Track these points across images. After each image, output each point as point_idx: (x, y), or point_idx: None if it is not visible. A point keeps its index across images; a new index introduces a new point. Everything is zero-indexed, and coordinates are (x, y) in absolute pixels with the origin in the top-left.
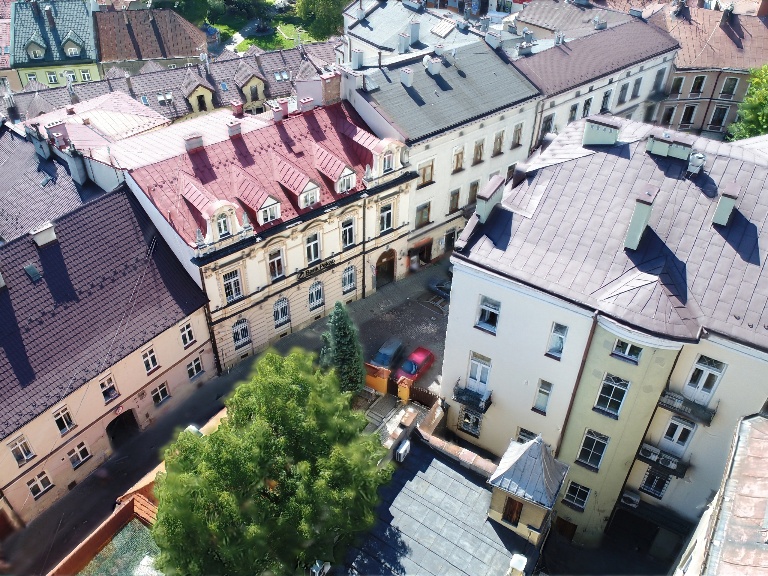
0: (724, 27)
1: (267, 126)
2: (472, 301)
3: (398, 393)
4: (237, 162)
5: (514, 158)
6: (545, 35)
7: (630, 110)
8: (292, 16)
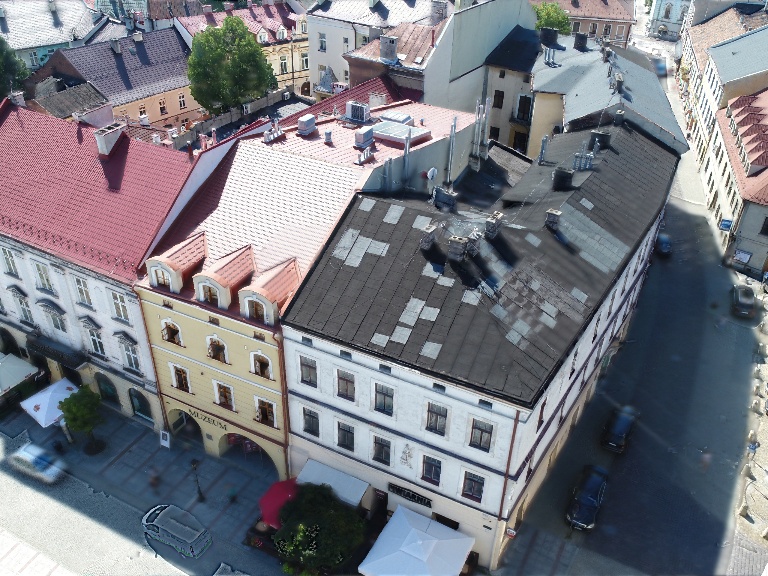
0: None
1: None
2: (316, 37)
3: None
4: None
5: None
6: None
7: None
8: None
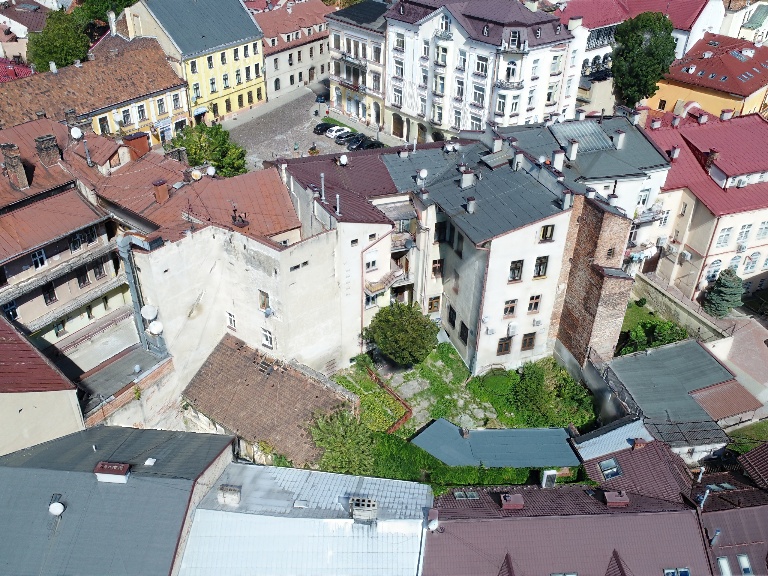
0: None
1: (682, 125)
2: None
3: None
4: None
5: None
6: None
7: None
8: None
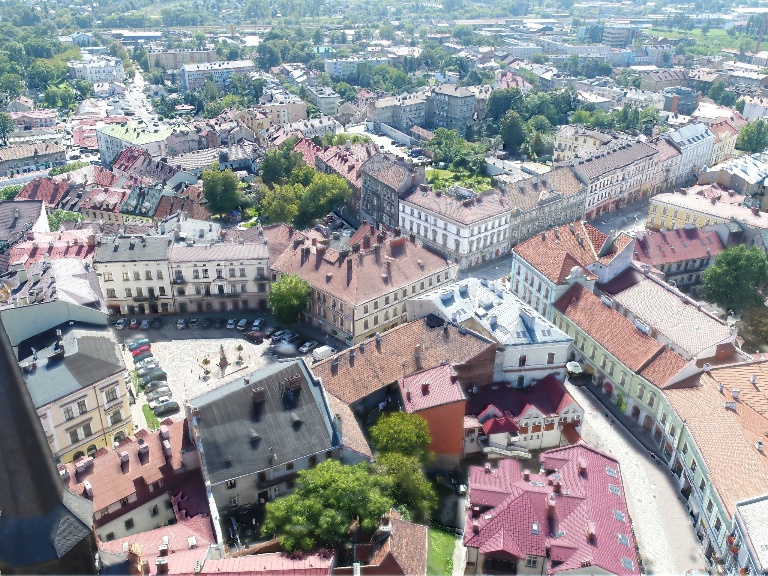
0: (302, 256)
1: None
2: None
3: None
4: None
5: (162, 284)
6: None
7: (243, 282)
8: None
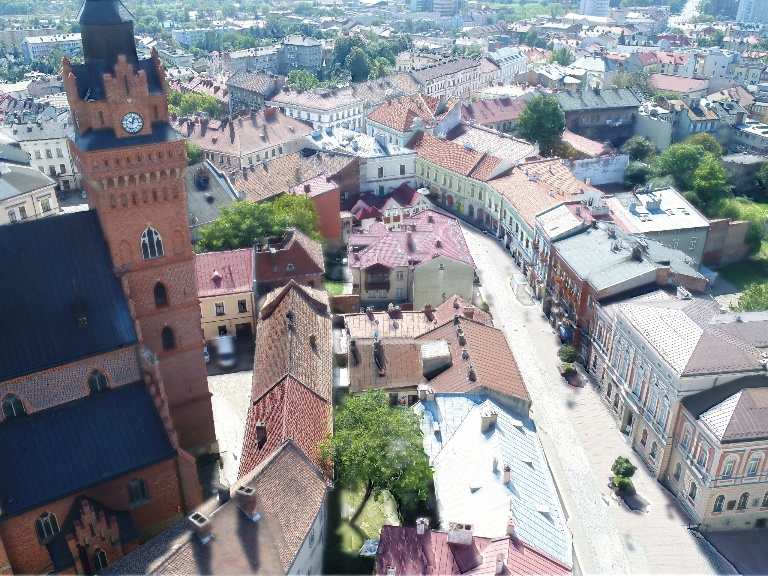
0: None
1: None
2: None
3: None
4: None
5: (62, 162)
6: None
7: None
8: None
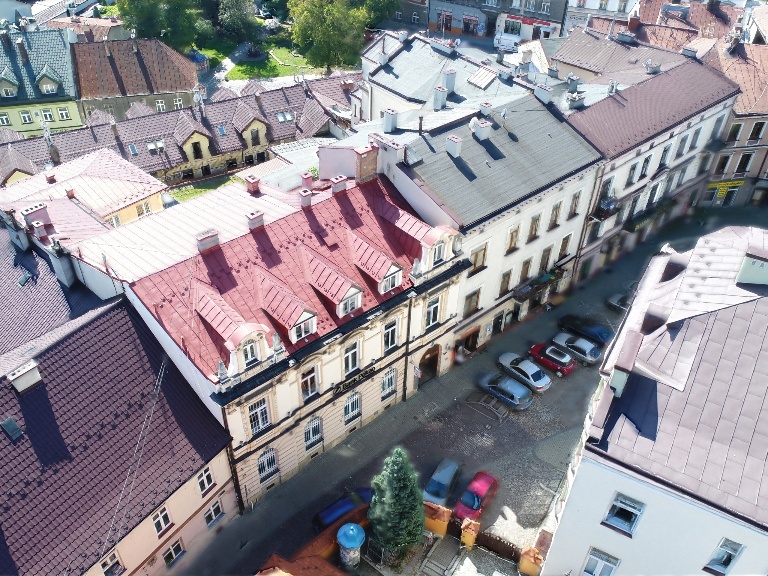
0: None
1: (293, 213)
2: (603, 497)
3: (461, 538)
4: (260, 262)
5: (569, 228)
6: (586, 77)
7: (686, 162)
8: (285, 38)
